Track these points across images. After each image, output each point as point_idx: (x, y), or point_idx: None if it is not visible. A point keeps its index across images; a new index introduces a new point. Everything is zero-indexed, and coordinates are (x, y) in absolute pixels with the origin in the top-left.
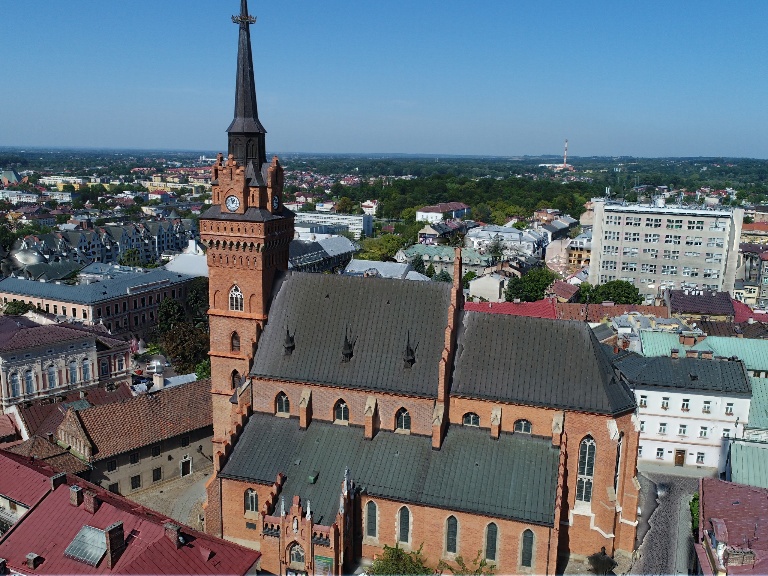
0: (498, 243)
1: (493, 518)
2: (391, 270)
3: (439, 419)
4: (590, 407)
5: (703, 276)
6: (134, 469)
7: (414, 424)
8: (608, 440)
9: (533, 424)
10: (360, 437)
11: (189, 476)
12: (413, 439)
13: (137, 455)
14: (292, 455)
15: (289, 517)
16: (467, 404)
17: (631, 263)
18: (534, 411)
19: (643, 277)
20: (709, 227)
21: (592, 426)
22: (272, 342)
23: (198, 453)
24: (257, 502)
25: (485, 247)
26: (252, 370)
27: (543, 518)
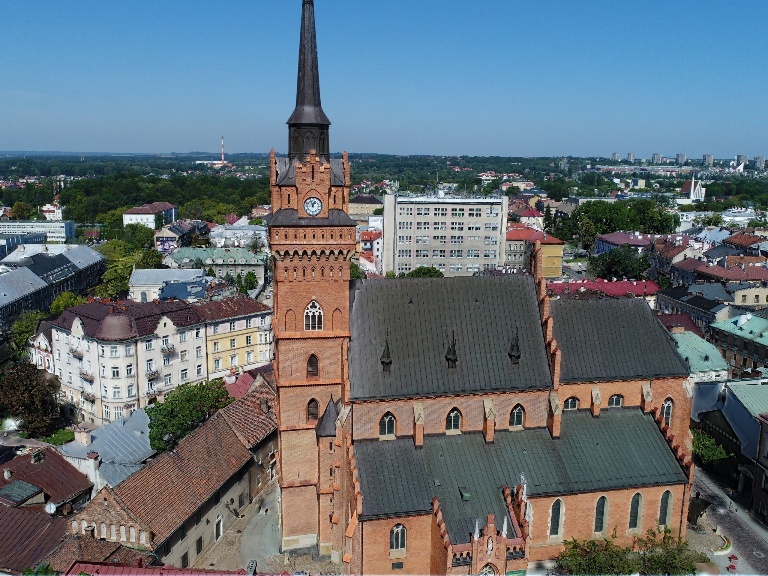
0: (256, 241)
1: (639, 489)
2: (185, 277)
3: (559, 408)
4: (670, 372)
5: (484, 257)
6: (183, 546)
7: (529, 418)
8: (685, 399)
9: (625, 397)
10: (480, 443)
11: (223, 538)
12: (530, 433)
13: (185, 527)
14: (426, 477)
15: (482, 540)
16: (569, 389)
17: (424, 250)
18: (626, 385)
19: (435, 262)
20: (486, 213)
21: (672, 389)
22: (364, 360)
23: (226, 509)
24: (403, 537)
25: (242, 246)
26: (351, 394)
27: (678, 477)
